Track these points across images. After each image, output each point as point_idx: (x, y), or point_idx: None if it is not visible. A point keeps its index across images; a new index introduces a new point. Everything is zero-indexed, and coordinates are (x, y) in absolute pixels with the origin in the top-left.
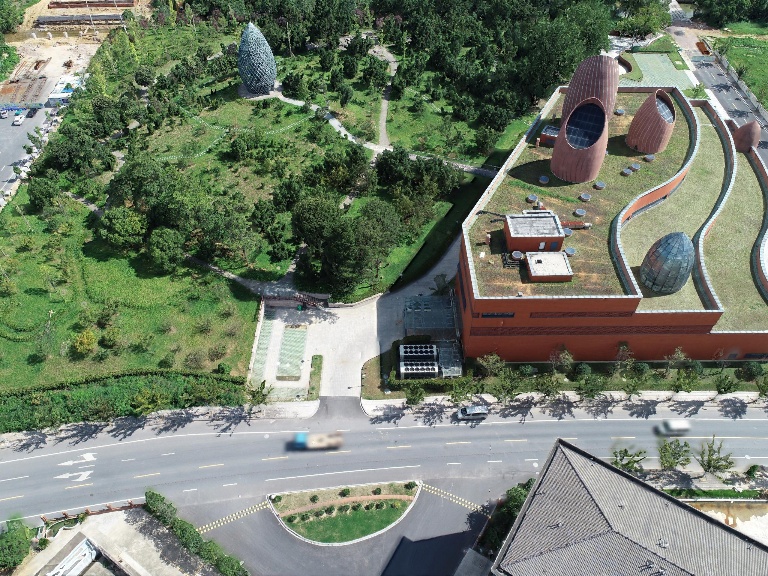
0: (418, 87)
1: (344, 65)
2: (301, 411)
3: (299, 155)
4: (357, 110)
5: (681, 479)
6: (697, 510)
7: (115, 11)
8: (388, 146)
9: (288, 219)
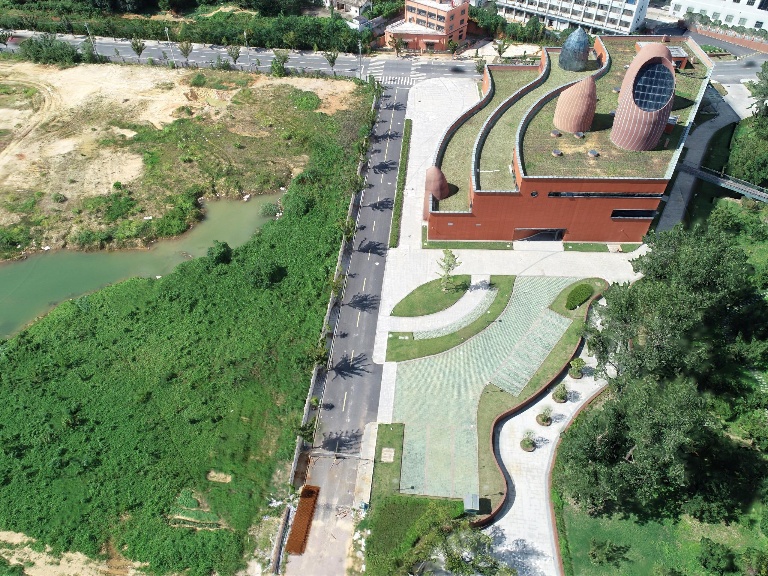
0: None
1: None
2: (748, 80)
3: None
4: None
5: None
6: None
7: None
8: None
9: None
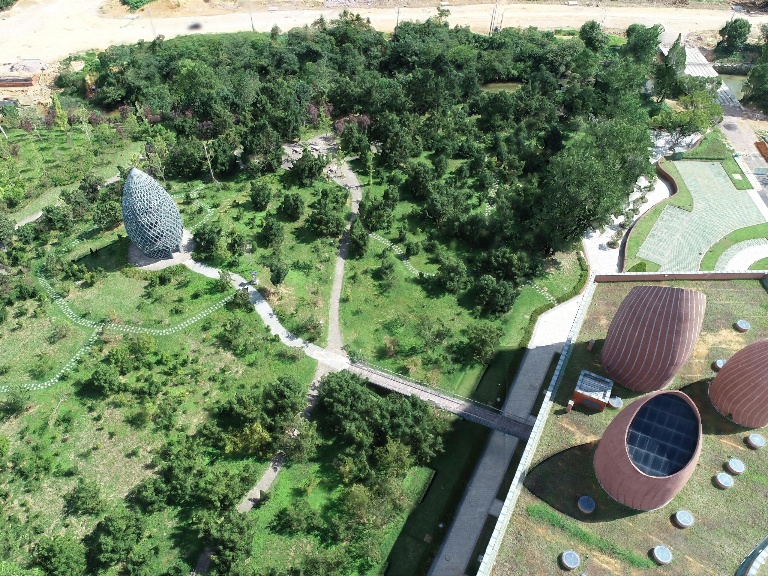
0: (388, 233)
1: (284, 204)
2: None
3: (203, 378)
4: (298, 281)
5: None
6: None
7: (8, 93)
8: (340, 351)
9: (168, 524)
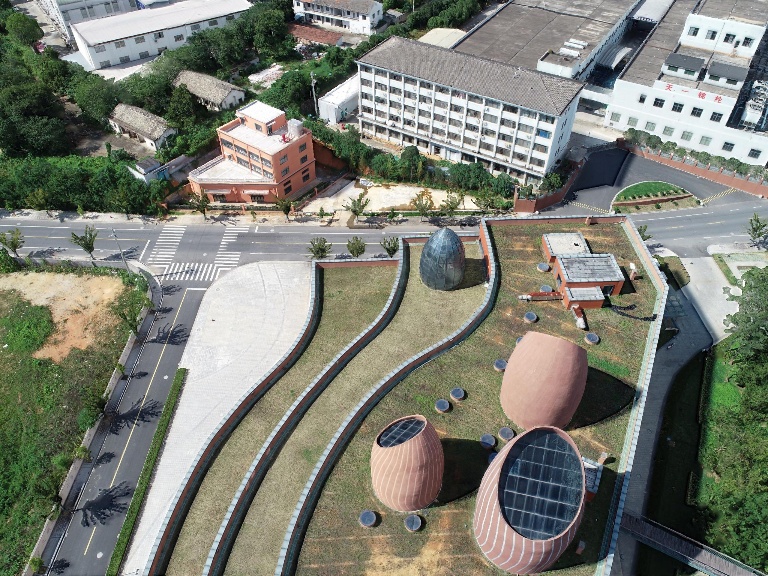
0: None
1: None
2: (719, 248)
3: None
4: None
5: (436, 221)
6: (490, 97)
7: None
8: None
9: None
